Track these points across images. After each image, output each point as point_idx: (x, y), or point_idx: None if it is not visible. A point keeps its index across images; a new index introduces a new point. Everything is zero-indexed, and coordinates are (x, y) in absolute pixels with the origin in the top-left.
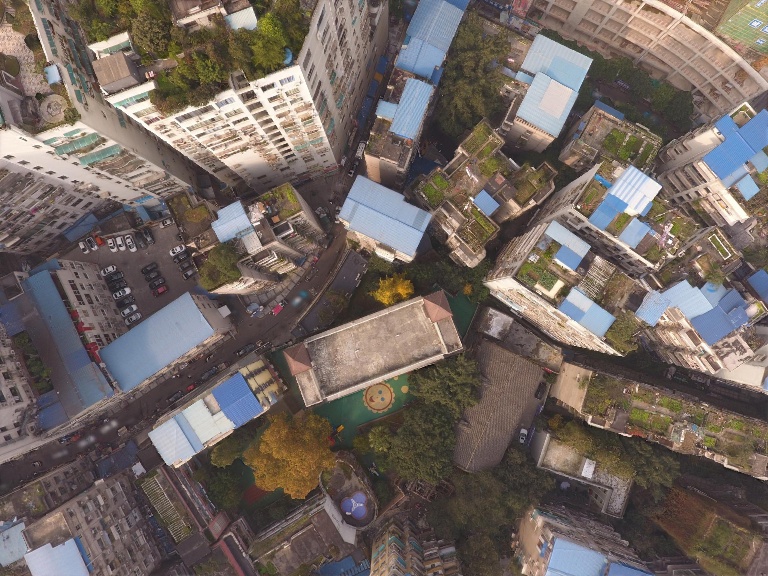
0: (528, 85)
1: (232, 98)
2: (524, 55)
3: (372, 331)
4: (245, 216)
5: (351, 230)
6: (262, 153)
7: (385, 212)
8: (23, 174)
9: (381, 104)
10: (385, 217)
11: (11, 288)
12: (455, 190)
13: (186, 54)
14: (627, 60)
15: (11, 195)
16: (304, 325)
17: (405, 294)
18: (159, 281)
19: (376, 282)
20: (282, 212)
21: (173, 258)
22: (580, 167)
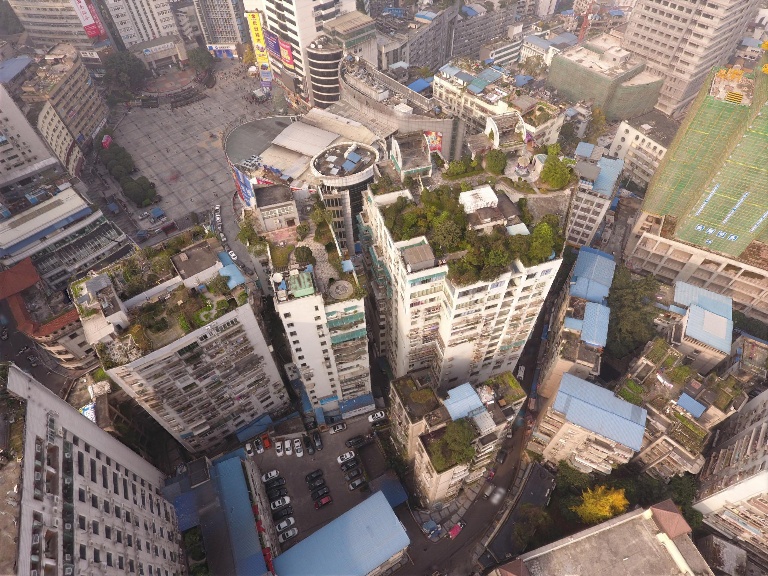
0: (681, 316)
1: (504, 281)
2: (668, 295)
3: (593, 552)
4: (476, 396)
5: (540, 437)
6: (477, 348)
7: (599, 406)
8: (258, 356)
9: (567, 320)
10: (601, 410)
11: (198, 474)
12: (651, 395)
13: (476, 248)
14: (739, 312)
15: (237, 376)
16: (493, 550)
17: (622, 506)
18: (324, 490)
19: (575, 496)
20: (506, 397)
21: (341, 465)
22: (749, 389)
